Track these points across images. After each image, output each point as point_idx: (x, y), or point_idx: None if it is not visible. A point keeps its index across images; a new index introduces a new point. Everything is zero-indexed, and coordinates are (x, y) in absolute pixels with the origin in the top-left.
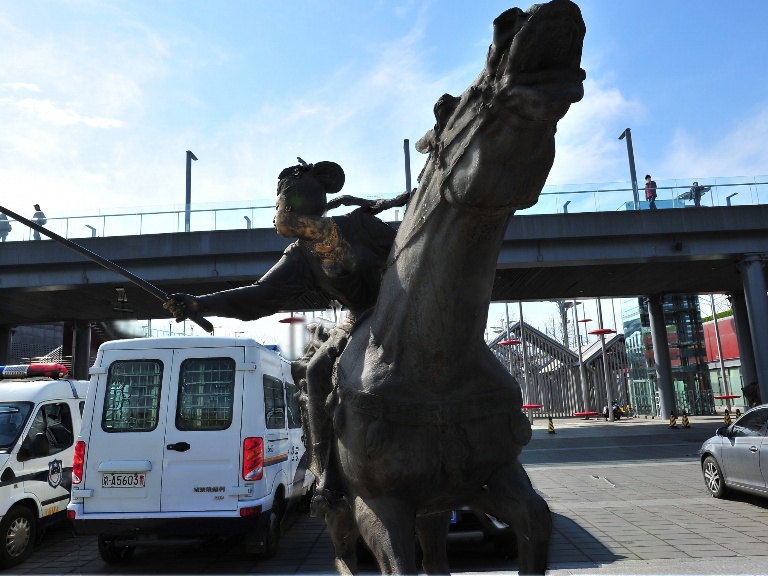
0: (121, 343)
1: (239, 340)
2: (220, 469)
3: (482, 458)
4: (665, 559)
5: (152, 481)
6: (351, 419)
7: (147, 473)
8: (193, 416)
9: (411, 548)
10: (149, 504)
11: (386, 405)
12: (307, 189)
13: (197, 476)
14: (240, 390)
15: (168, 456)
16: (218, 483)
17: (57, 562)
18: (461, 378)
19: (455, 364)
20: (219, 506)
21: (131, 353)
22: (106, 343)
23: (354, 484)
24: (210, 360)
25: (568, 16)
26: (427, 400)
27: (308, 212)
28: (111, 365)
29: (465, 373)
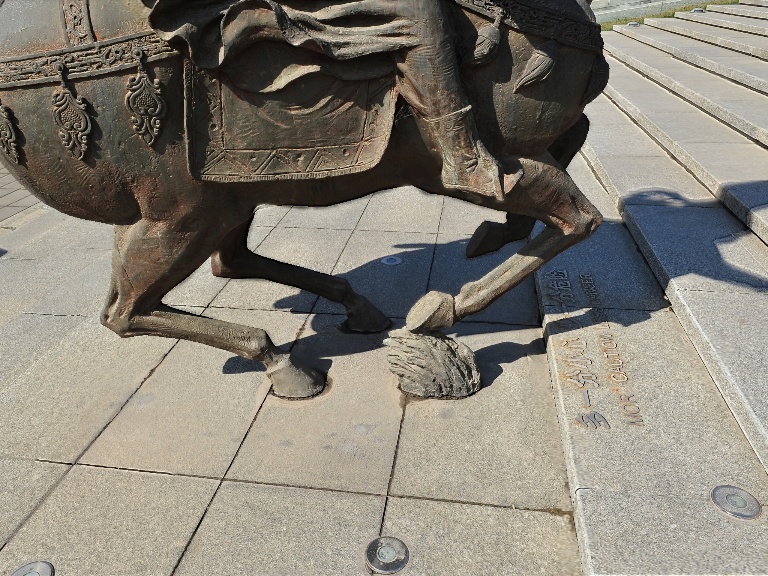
0: None
1: None
2: None
3: None
4: (11, 217)
5: None
6: (578, 62)
7: None
8: None
9: None
10: None
11: None
12: None
13: None
14: None
15: None
16: None
17: None
18: None
19: None
20: None
21: None
22: None
23: (531, 144)
24: None
25: None
26: None
27: None
28: None
29: None
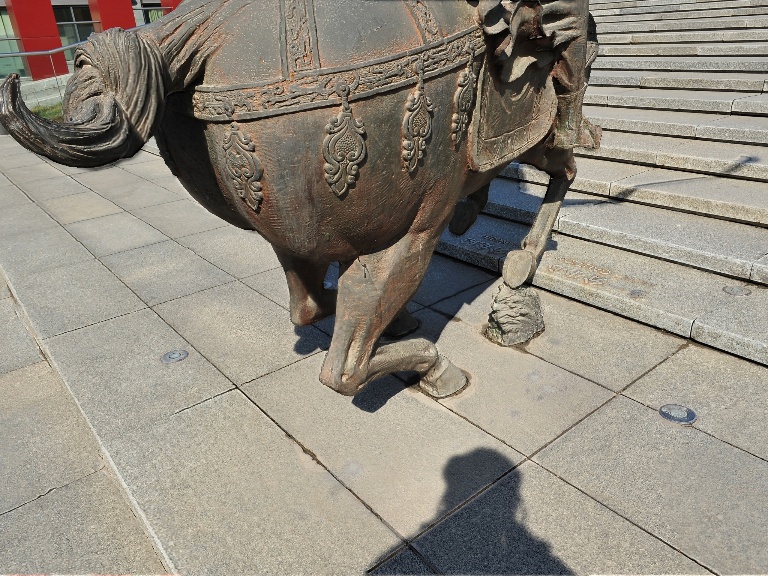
0: None
1: None
2: None
3: None
4: None
5: None
6: None
7: None
8: None
9: None
10: None
11: None
12: None
13: None
14: None
15: None
16: None
17: None
18: None
19: None
20: None
21: None
22: None
23: None
24: None
25: None
26: None
27: None
28: None
29: None
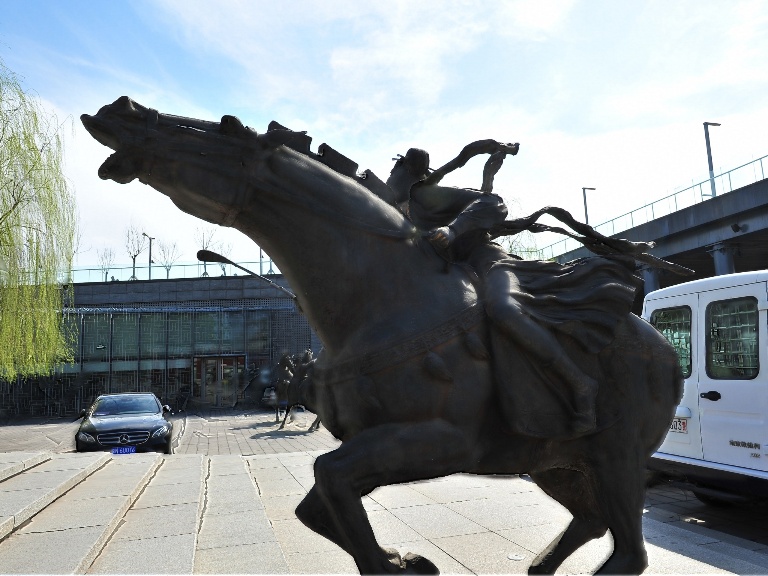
0: (658, 292)
1: (761, 274)
2: (752, 423)
3: (344, 419)
4: None
5: (693, 428)
6: None
7: (688, 420)
8: (735, 363)
9: None
10: (694, 451)
11: (313, 370)
12: (393, 182)
13: (731, 428)
14: (765, 333)
15: (702, 404)
16: (752, 439)
17: (673, 493)
18: (335, 347)
19: (320, 336)
20: (757, 465)
21: (665, 301)
22: (648, 294)
23: None
24: (737, 301)
25: (84, 121)
26: (323, 366)
27: (396, 201)
28: (652, 315)
29: (338, 342)
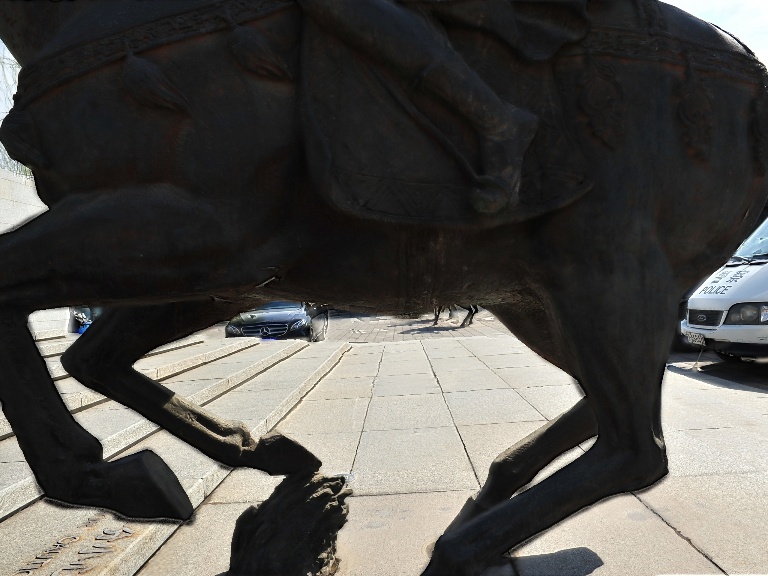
0: None
1: None
2: None
3: None
4: None
5: None
6: None
7: None
8: None
9: (113, 322)
10: None
11: None
12: None
13: None
14: None
15: None
16: None
17: None
18: None
19: None
20: None
21: None
22: None
23: None
24: None
25: None
26: None
27: None
28: None
29: None
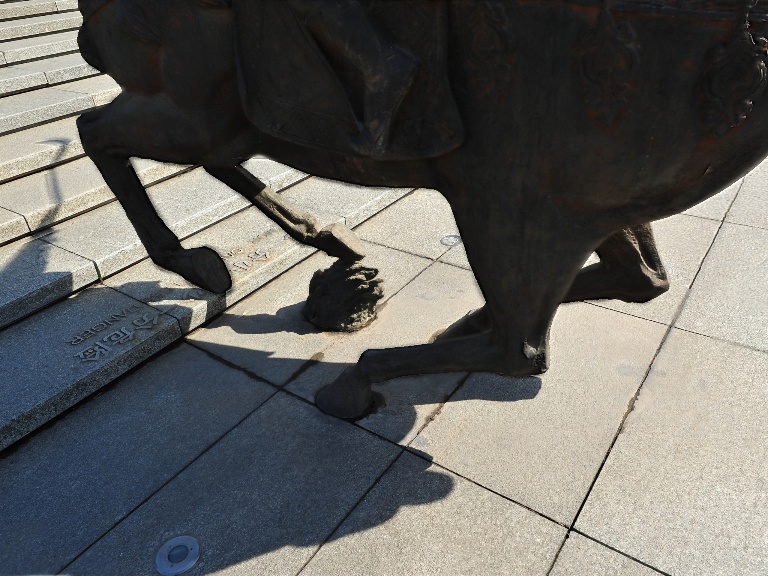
0: None
1: None
2: None
3: None
4: None
5: None
6: None
7: None
8: None
9: None
10: None
11: None
12: None
13: None
14: None
15: None
16: None
17: None
18: None
19: None
20: None
21: None
22: None
23: None
24: None
25: None
26: None
27: None
28: None
29: None
